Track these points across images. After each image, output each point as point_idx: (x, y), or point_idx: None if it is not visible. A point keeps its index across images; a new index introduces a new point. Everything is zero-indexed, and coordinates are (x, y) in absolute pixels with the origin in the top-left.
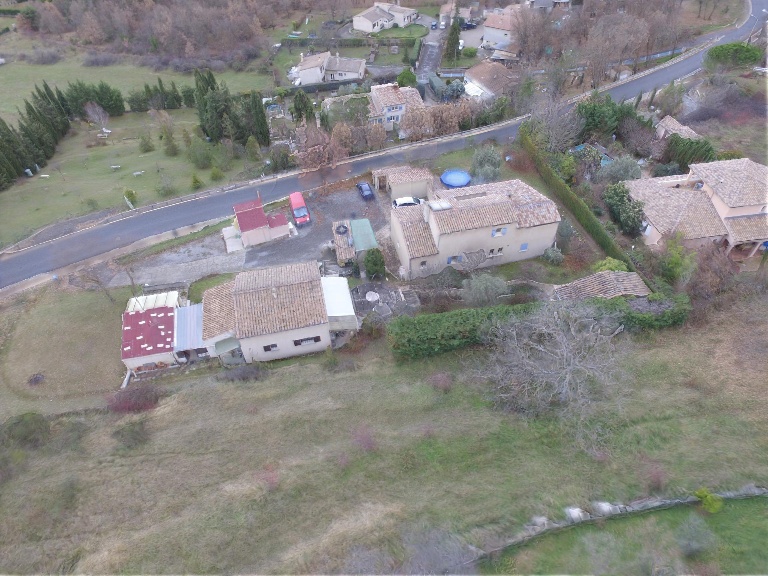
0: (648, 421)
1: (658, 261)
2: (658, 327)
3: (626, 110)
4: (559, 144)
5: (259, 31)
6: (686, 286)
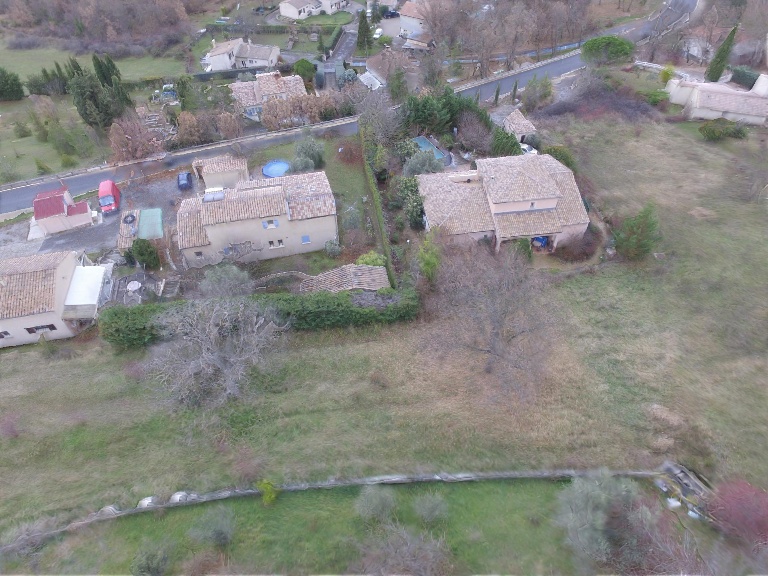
0: (301, 413)
1: (410, 256)
2: (384, 321)
3: (466, 103)
4: (383, 136)
5: (183, 16)
6: (417, 281)
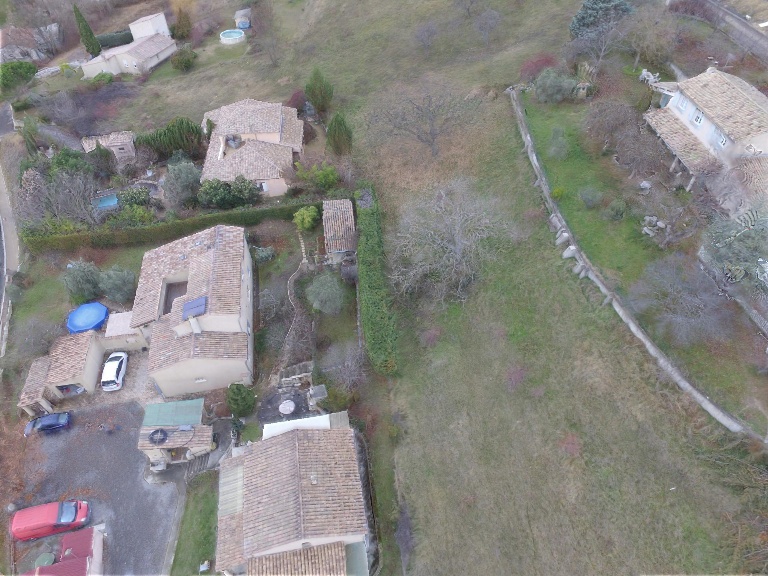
0: None
1: (314, 187)
2: None
3: (69, 154)
4: (98, 211)
5: None
6: (352, 178)
